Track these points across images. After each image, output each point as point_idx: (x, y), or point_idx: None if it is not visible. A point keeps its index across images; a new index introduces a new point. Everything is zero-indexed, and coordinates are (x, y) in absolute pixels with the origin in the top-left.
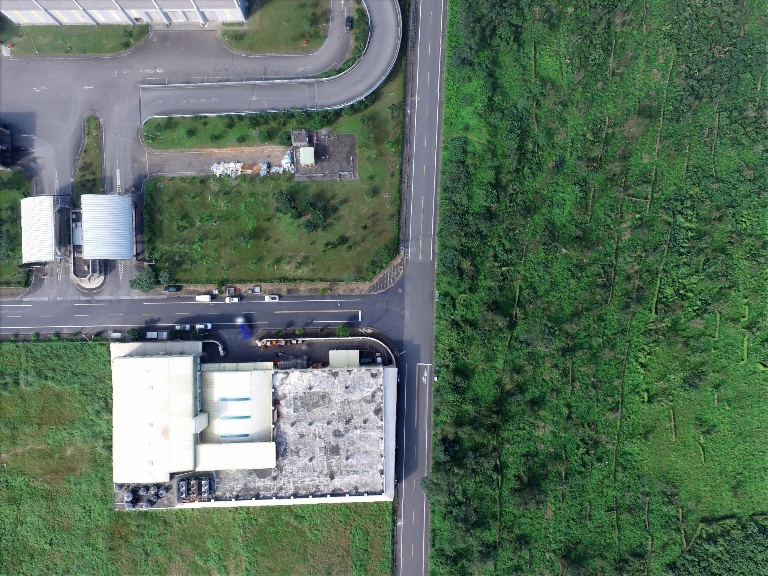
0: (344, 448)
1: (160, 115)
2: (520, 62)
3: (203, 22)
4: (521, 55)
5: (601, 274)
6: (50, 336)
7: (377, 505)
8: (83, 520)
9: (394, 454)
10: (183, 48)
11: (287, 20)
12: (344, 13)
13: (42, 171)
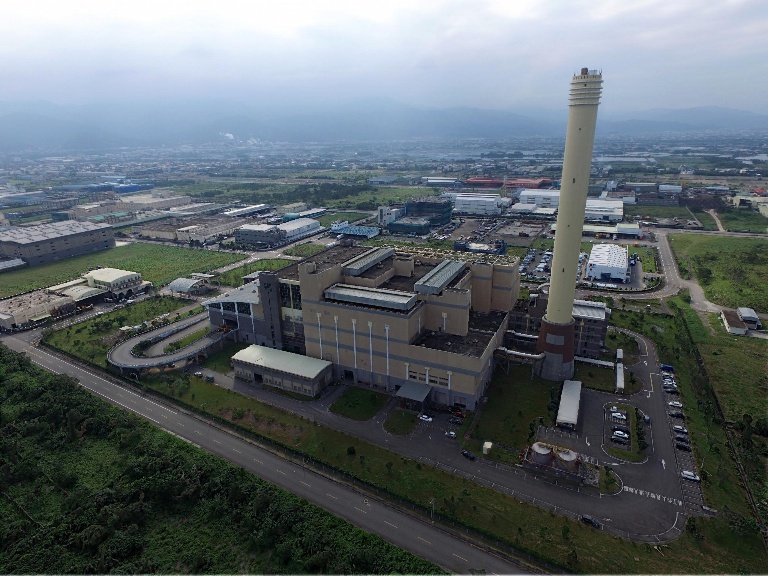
0: None
1: None
2: None
3: None
4: None
5: None
6: None
7: None
8: None
9: None
10: None
11: None
12: None
13: None
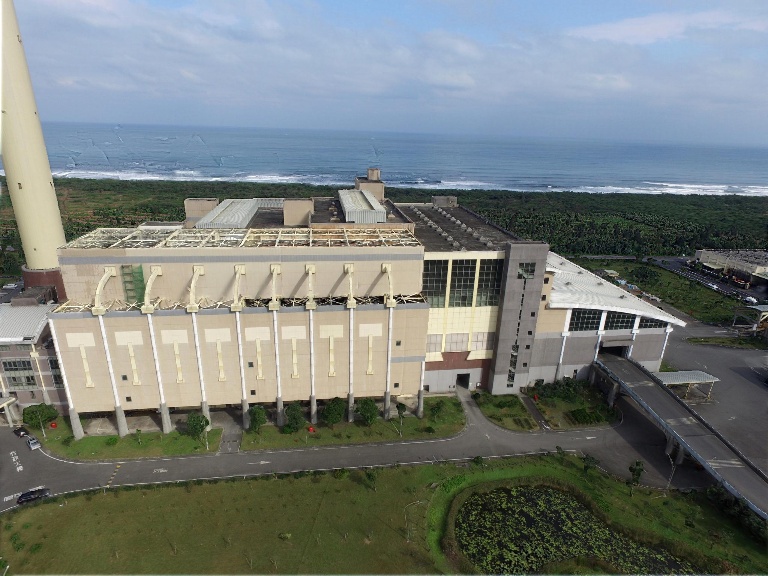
0: None
1: None
2: None
3: None
4: None
5: None
6: None
7: None
8: None
9: None
10: None
11: None
12: None
13: None
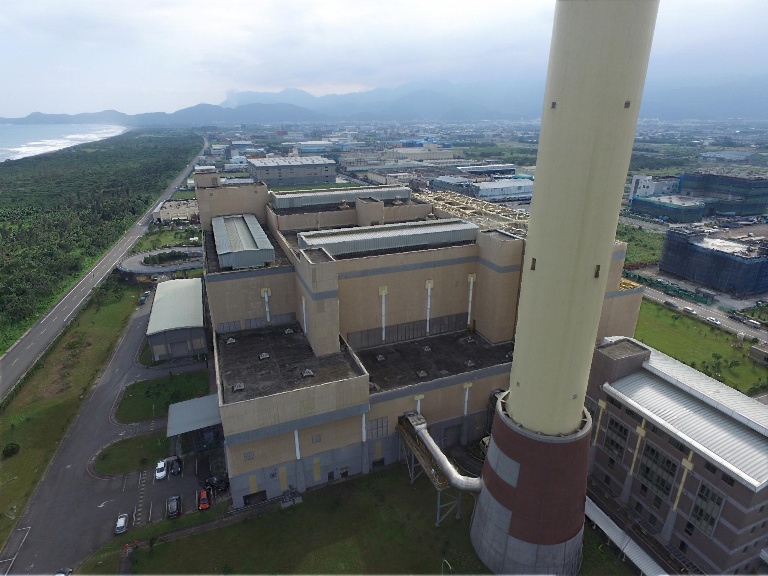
0: None
1: None
2: None
3: None
4: None
5: None
6: None
7: None
8: None
9: None
10: None
11: None
12: None
13: None
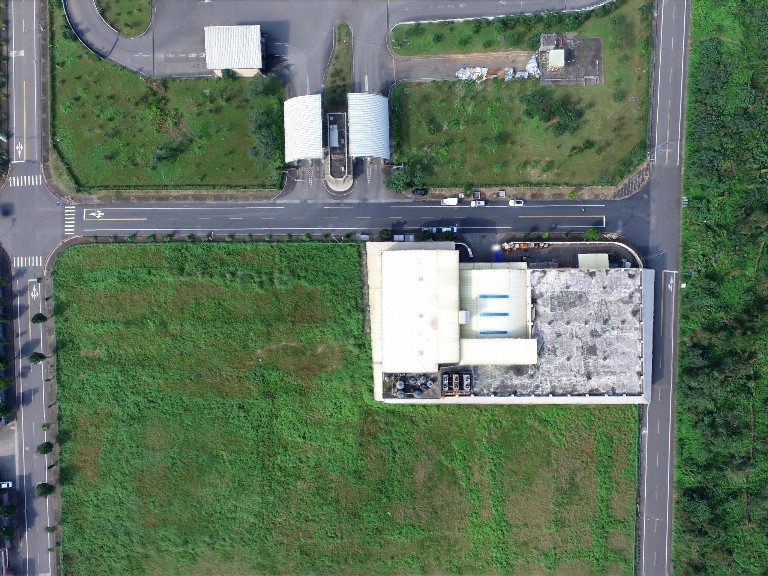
0: (601, 348)
1: (408, 21)
2: None
3: None
4: None
5: None
6: (302, 237)
7: (622, 412)
8: (335, 415)
9: (651, 356)
10: None
11: None
12: None
13: (294, 78)
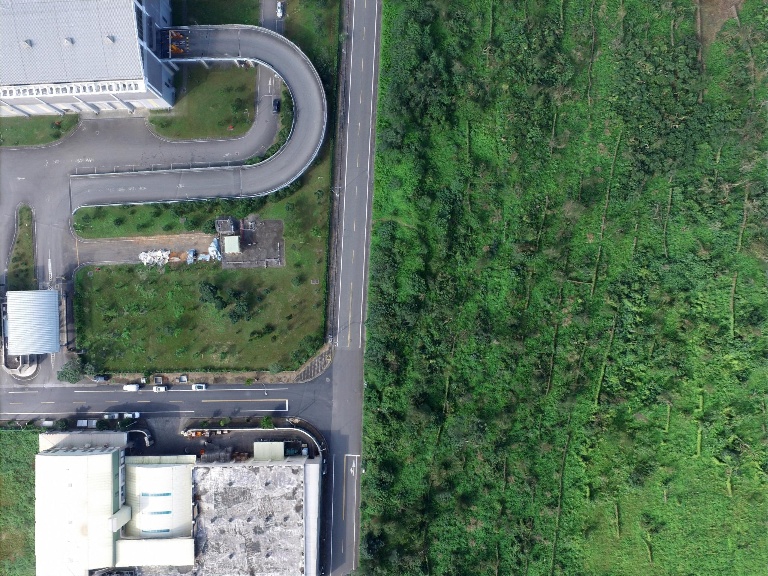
0: (265, 545)
1: (89, 204)
2: (454, 140)
3: (130, 110)
4: (455, 133)
5: (538, 364)
6: None
7: None
8: None
9: (316, 552)
10: (111, 136)
11: (214, 105)
12: (271, 95)
13: None
